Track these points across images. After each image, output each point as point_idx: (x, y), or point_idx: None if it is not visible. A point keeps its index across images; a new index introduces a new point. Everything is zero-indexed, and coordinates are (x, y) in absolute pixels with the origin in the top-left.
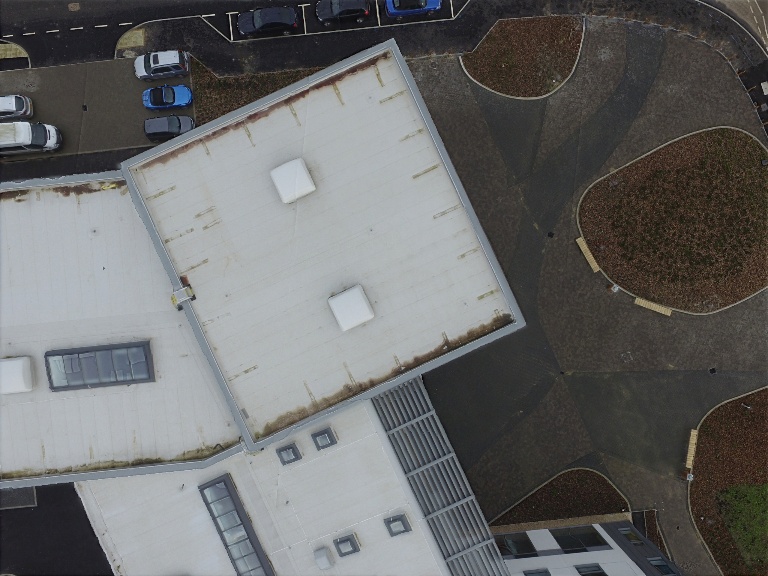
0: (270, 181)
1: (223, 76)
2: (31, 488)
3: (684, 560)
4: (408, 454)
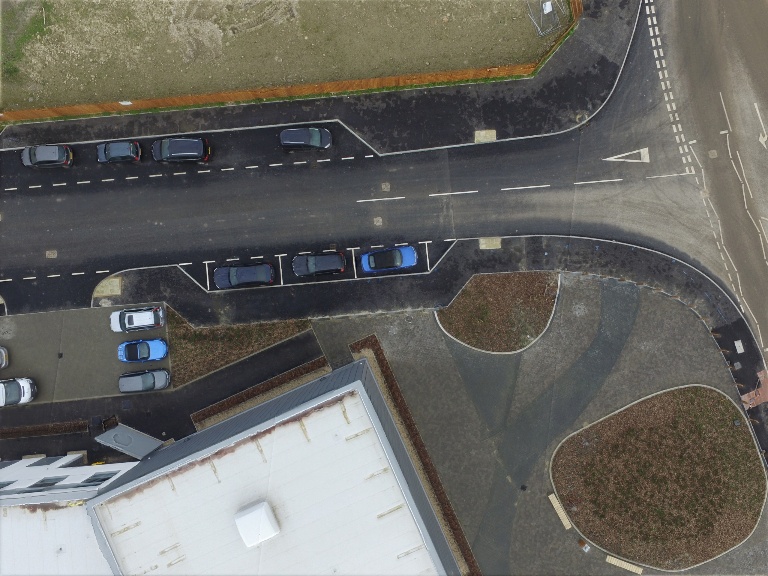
0: None
1: (199, 327)
2: None
3: None
4: None
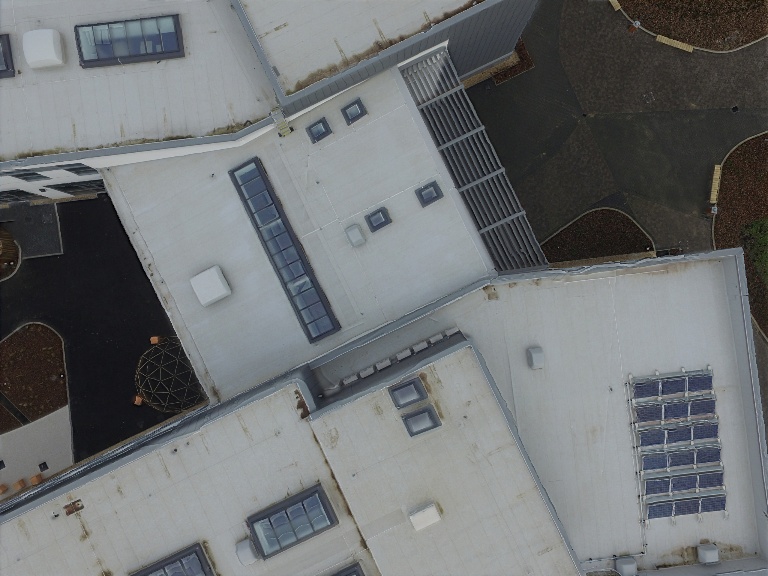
0: None
1: None
2: (57, 236)
3: None
4: (438, 129)
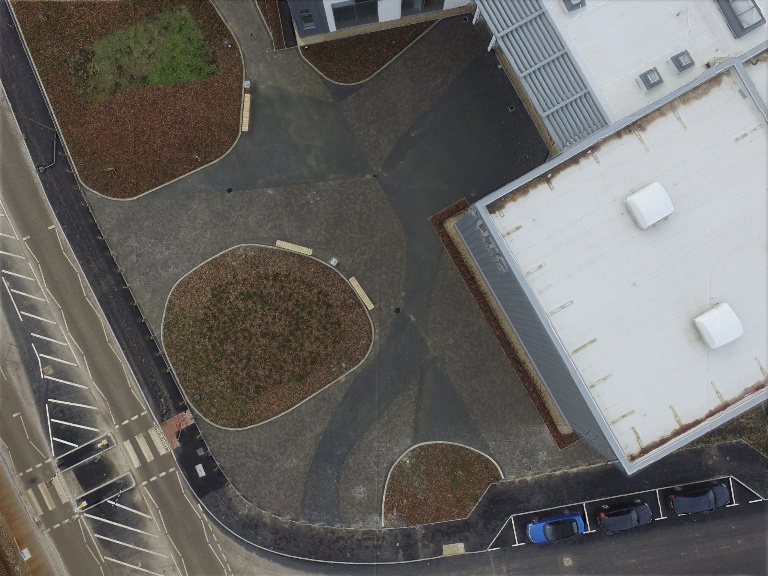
0: None
1: (737, 441)
2: None
3: (244, 4)
4: (565, 72)
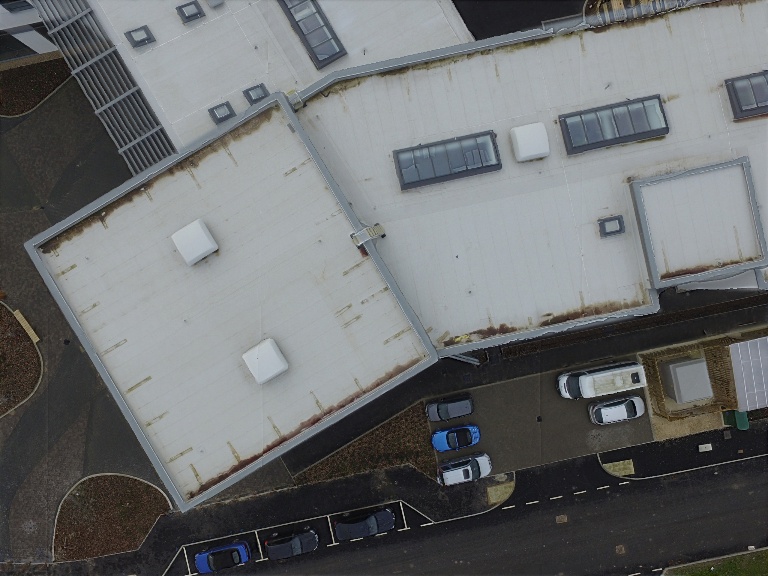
0: (292, 359)
1: (405, 465)
2: None
3: None
4: (141, 107)
